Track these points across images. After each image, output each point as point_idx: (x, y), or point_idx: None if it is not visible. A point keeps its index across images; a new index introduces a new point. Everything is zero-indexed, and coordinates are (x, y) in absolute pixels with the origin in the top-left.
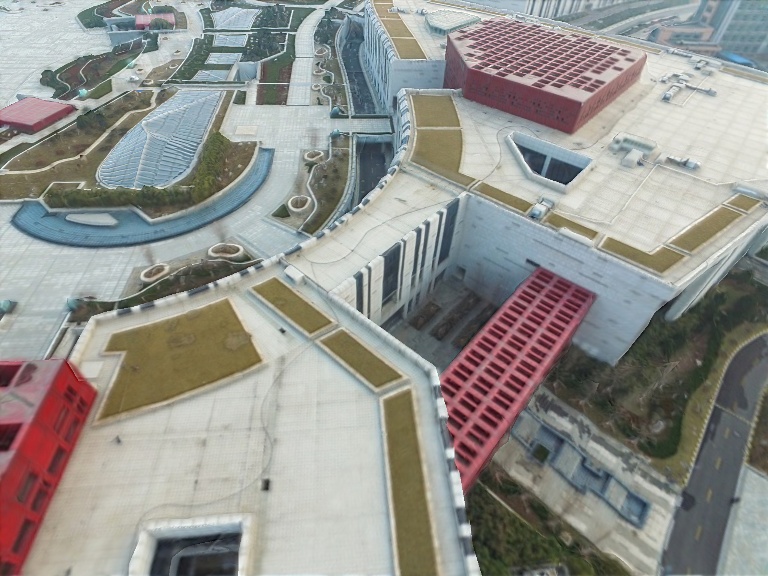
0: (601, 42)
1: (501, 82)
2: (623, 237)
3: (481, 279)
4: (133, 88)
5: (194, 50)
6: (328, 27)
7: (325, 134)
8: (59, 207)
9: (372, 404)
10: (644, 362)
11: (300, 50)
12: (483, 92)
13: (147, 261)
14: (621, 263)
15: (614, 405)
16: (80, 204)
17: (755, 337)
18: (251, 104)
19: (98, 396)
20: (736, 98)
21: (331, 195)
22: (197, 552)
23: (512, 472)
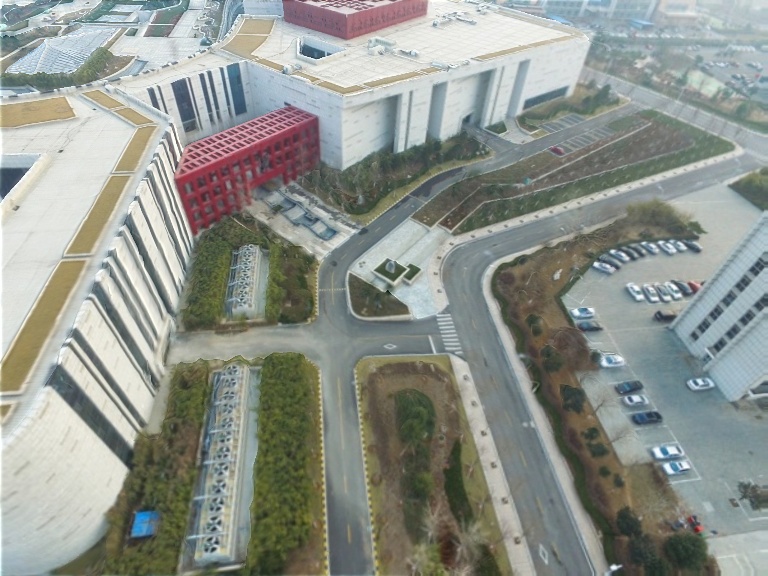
0: None
1: (302, 5)
2: (336, 82)
3: None
4: (46, 25)
5: (102, 2)
6: None
7: None
8: None
9: (132, 131)
10: None
11: (193, 5)
12: (294, 15)
13: None
14: (319, 88)
15: None
16: None
17: (457, 167)
18: (139, 36)
19: None
20: (489, 26)
21: None
22: None
23: (256, 216)
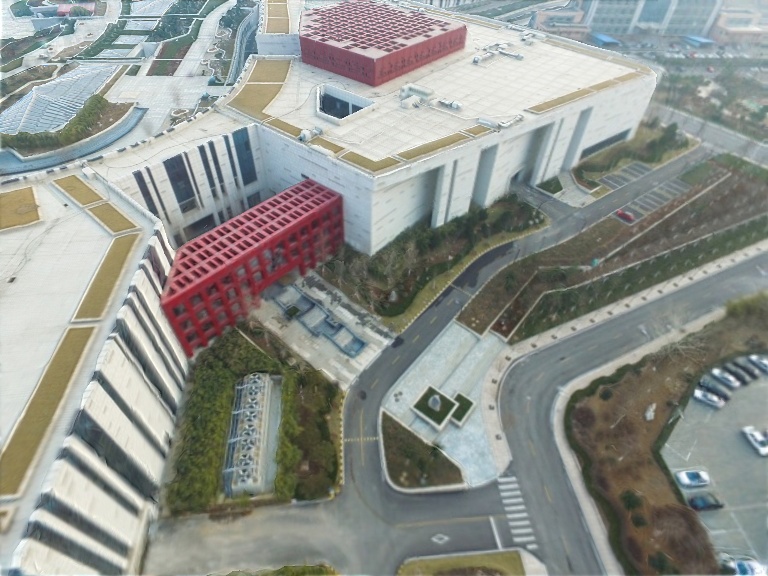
0: (431, 17)
1: (322, 46)
2: (364, 152)
3: None
4: (41, 64)
5: (104, 33)
6: (237, 14)
7: (197, 97)
8: None
9: (108, 242)
10: None
11: (203, 33)
12: (313, 56)
13: None
14: (344, 165)
15: None
16: None
17: (507, 242)
18: (142, 75)
19: None
20: (538, 61)
21: None
22: None
23: (266, 323)
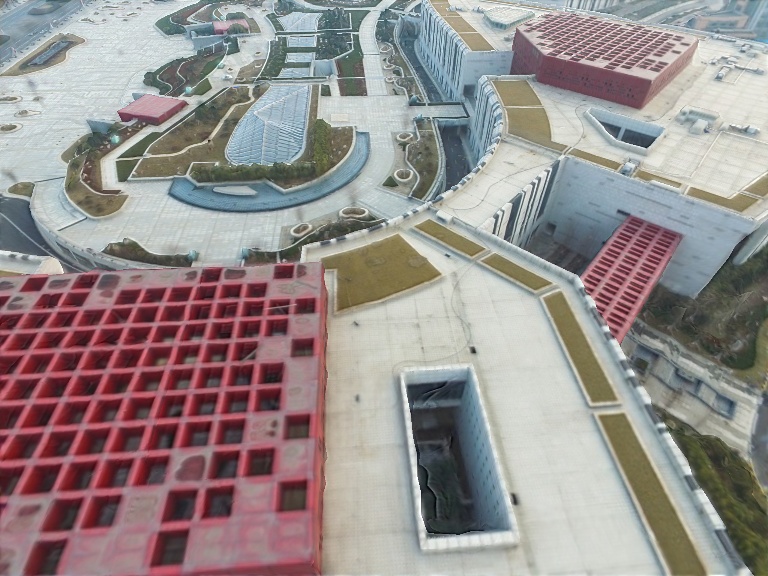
0: (655, 30)
1: (575, 66)
2: (703, 187)
3: (571, 232)
4: (229, 85)
5: (273, 51)
6: (385, 27)
7: (409, 119)
8: (205, 182)
9: (534, 301)
10: (720, 296)
11: (366, 48)
12: (557, 76)
13: (291, 222)
14: (707, 205)
15: (697, 329)
16: (223, 178)
17: None
18: (337, 96)
19: (329, 297)
20: None
21: (429, 168)
22: (415, 406)
23: None
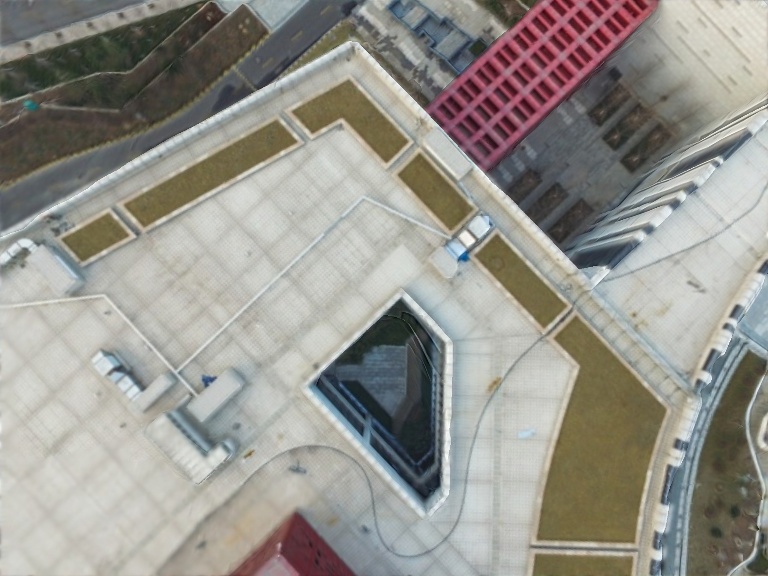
0: None
1: None
2: (359, 166)
3: None
4: None
5: None
6: None
7: None
8: None
9: None
10: None
11: None
12: None
13: None
14: None
15: None
16: None
17: None
18: None
19: None
20: None
21: (722, 454)
22: None
23: None
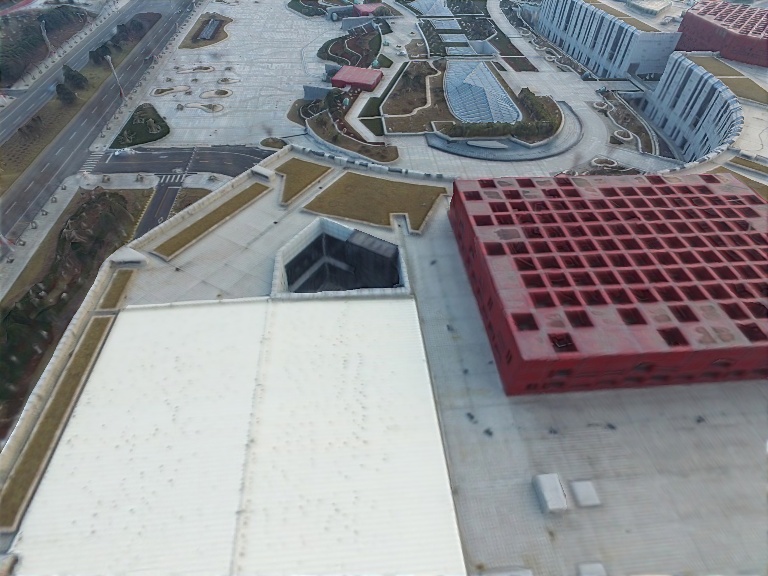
0: None
1: None
2: None
3: None
4: (407, 60)
5: (428, 31)
6: None
7: (591, 91)
8: (457, 136)
9: None
10: None
11: (506, 32)
12: (746, 52)
13: (554, 169)
14: None
15: None
16: (474, 134)
17: None
18: (512, 71)
19: None
20: None
21: (641, 130)
22: None
23: None
